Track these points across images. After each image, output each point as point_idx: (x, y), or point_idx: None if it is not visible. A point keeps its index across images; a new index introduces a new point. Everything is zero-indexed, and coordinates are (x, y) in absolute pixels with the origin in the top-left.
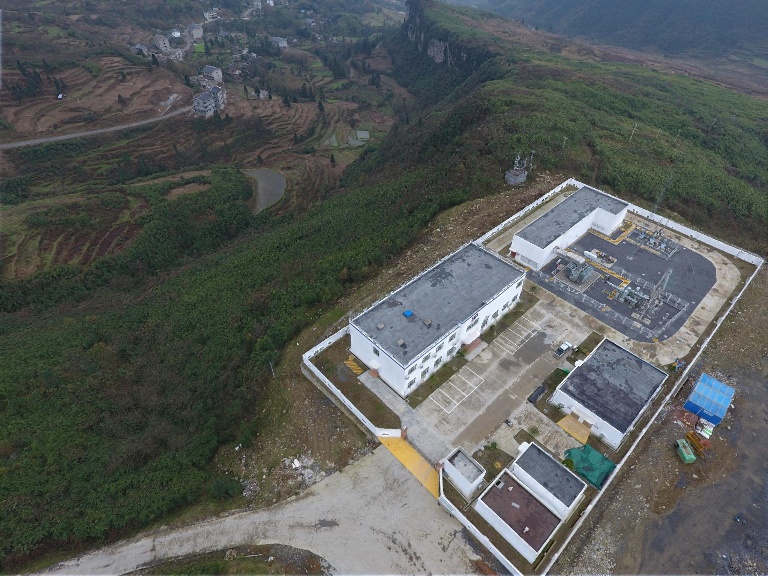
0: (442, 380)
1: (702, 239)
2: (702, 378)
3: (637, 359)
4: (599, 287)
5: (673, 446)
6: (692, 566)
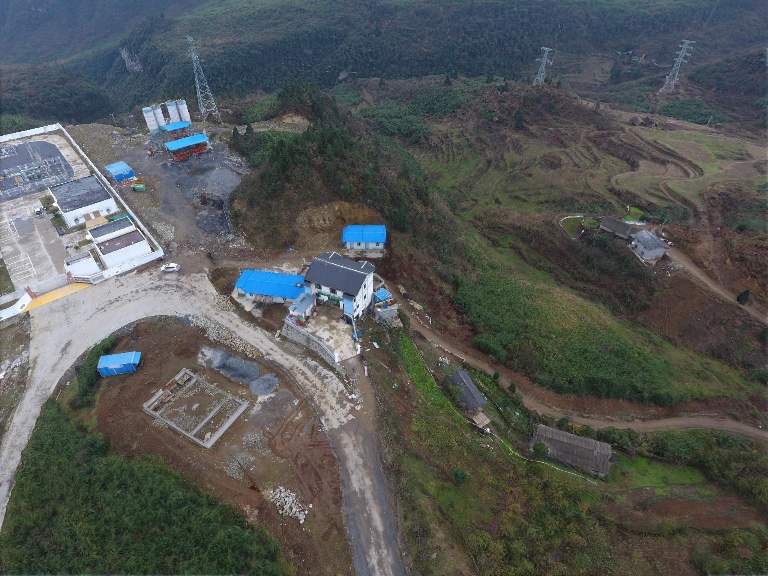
0: (5, 274)
1: (17, 136)
2: (107, 168)
3: (74, 182)
4: (6, 187)
5: (134, 191)
6: (186, 204)
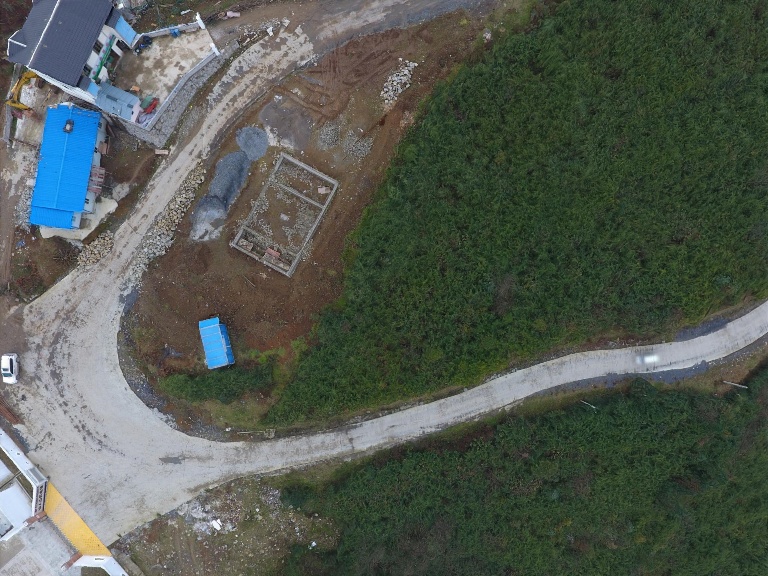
0: None
1: None
2: None
3: None
4: None
5: None
6: None
